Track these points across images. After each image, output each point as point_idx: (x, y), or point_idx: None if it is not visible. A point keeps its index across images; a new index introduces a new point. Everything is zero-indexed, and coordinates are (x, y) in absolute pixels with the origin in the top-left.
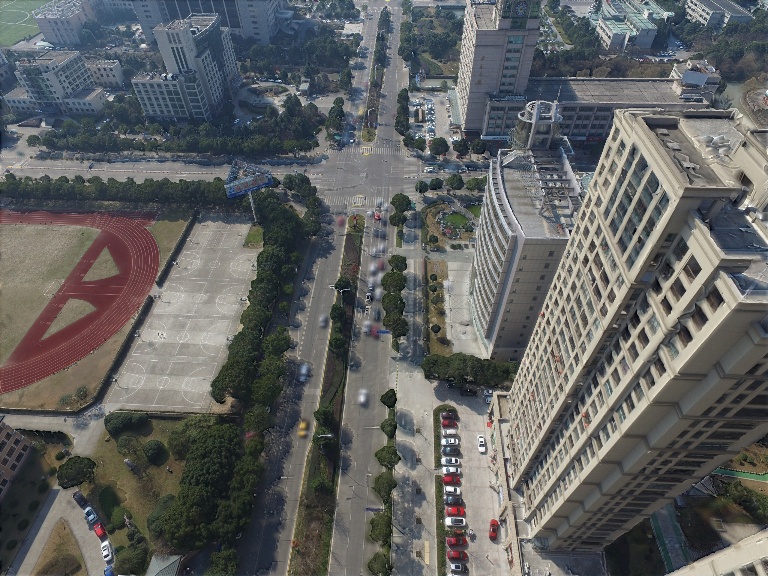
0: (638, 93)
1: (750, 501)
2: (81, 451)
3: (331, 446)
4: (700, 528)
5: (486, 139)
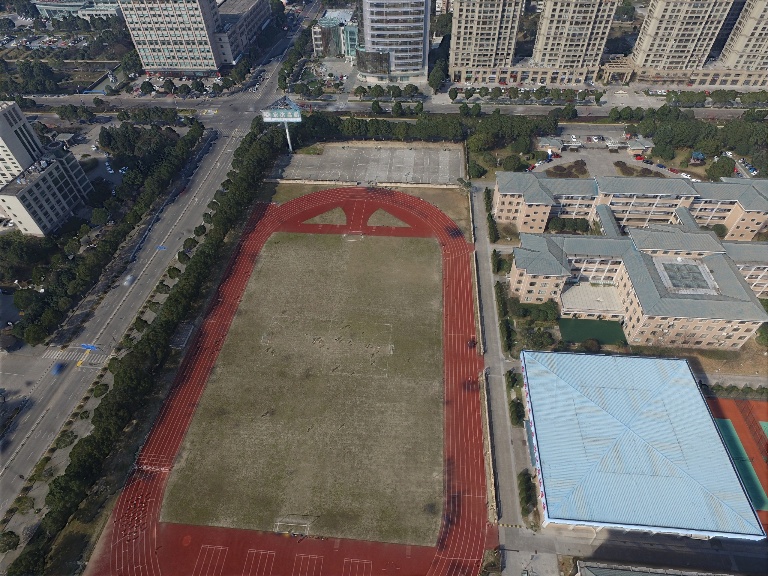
0: (242, 2)
1: None
2: (493, 185)
3: None
4: None
5: (236, 62)
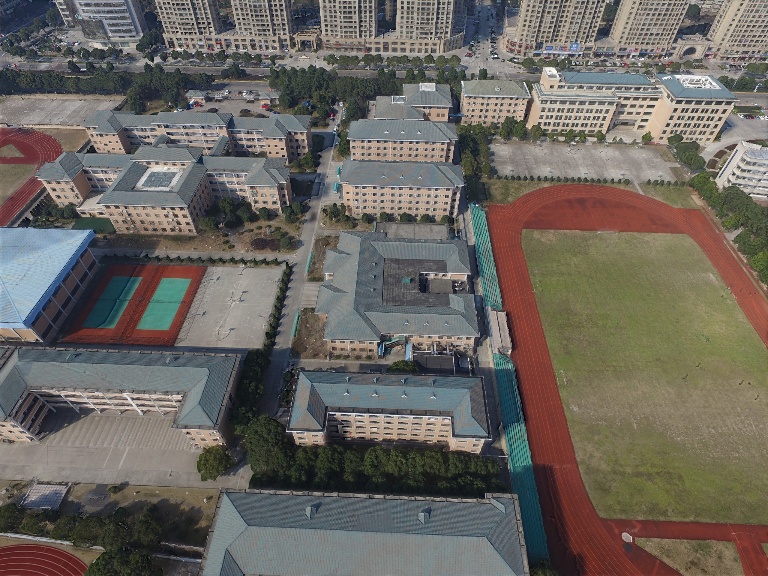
0: None
1: (222, 15)
2: None
3: (163, 69)
4: (226, 24)
5: None
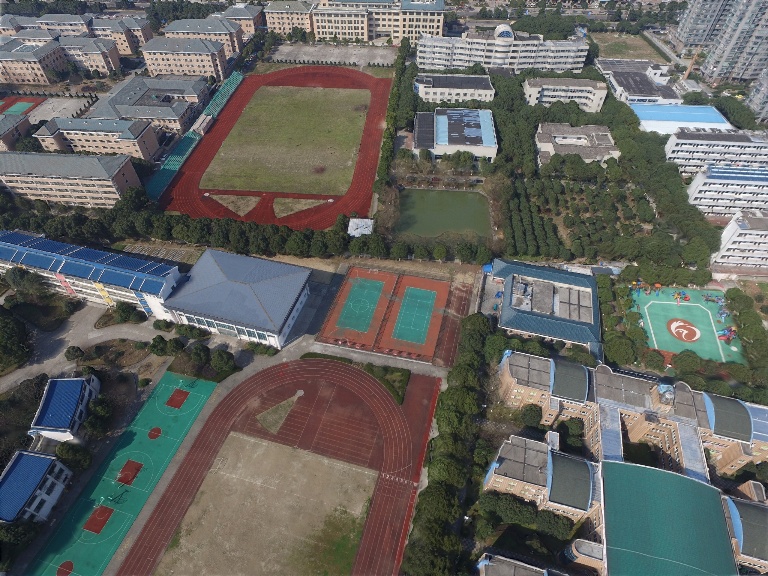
0: None
1: None
2: None
3: None
4: None
5: None
